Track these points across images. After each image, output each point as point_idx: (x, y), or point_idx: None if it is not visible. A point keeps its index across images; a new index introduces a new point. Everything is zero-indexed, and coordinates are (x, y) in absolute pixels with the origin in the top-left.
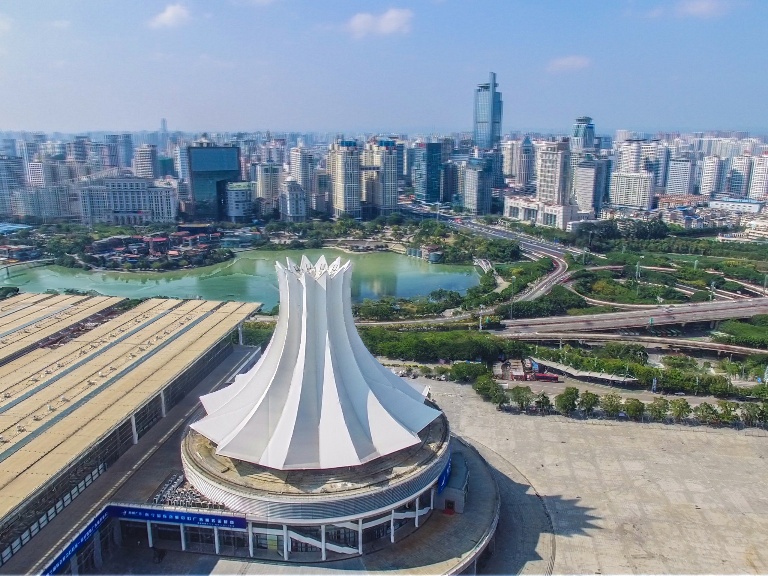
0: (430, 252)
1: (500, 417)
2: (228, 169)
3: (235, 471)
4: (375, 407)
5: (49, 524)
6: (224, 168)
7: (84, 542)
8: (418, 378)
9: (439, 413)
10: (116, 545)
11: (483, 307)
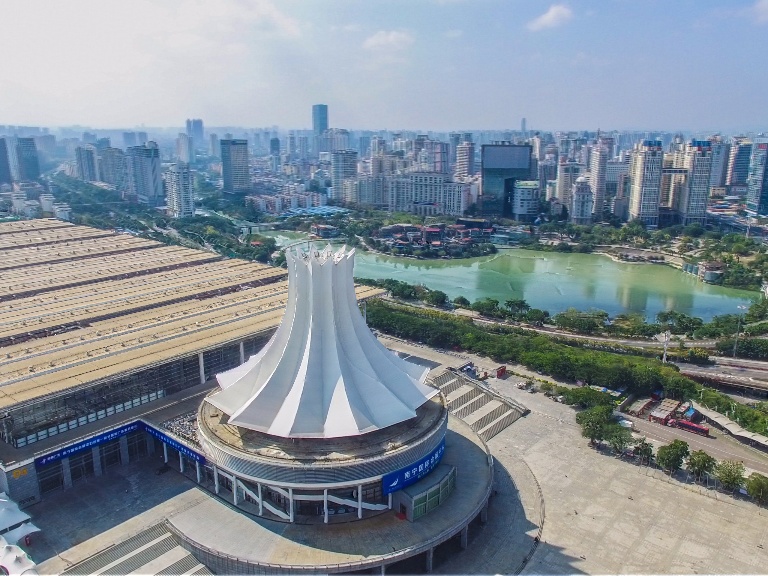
0: (707, 270)
1: (583, 453)
2: (518, 167)
3: (219, 418)
4: (341, 393)
5: (97, 421)
6: (514, 166)
7: (108, 440)
8: (535, 393)
9: (412, 415)
10: (147, 453)
11: (669, 334)
